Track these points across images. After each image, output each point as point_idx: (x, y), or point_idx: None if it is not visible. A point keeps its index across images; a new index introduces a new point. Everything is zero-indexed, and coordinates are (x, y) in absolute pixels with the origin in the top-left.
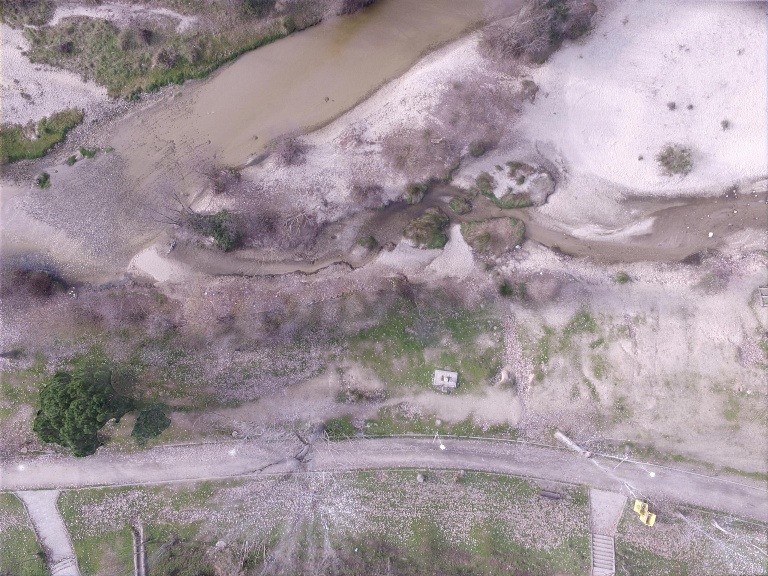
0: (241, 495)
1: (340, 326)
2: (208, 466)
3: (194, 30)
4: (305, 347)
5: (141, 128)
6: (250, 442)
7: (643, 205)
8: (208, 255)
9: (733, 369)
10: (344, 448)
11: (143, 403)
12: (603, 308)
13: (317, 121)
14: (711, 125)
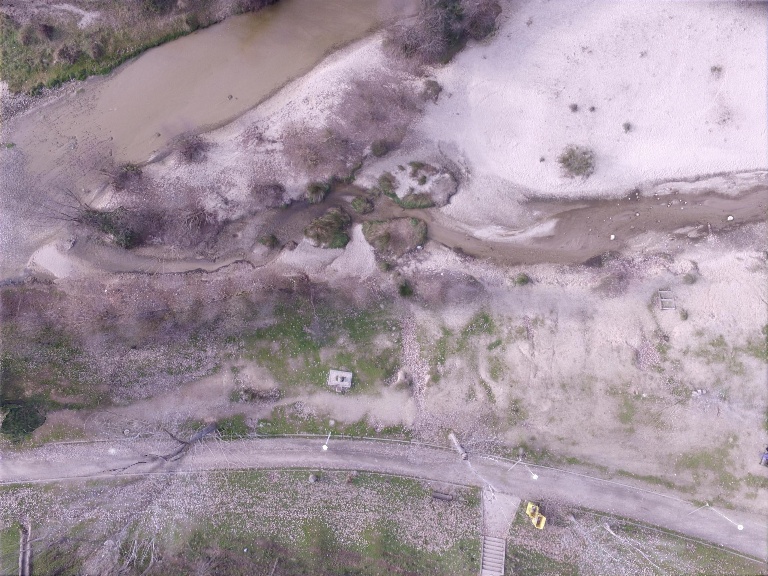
0: (132, 494)
1: (238, 325)
2: (99, 464)
3: (96, 26)
4: (201, 345)
5: (43, 124)
6: (142, 440)
7: (545, 207)
8: (109, 252)
9: (629, 372)
10: (237, 447)
11: (34, 400)
12: (502, 309)
13: (220, 119)
14: (613, 127)
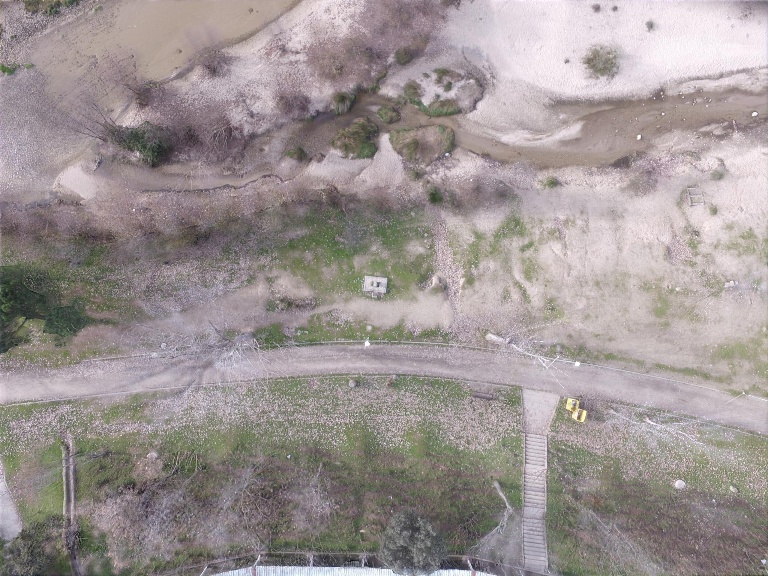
0: (172, 407)
1: (269, 237)
2: (137, 379)
3: None
4: (234, 258)
5: (62, 43)
6: (179, 353)
7: (571, 109)
8: (135, 171)
9: (662, 267)
10: (275, 357)
11: None
12: (533, 212)
13: (242, 33)
14: (636, 26)
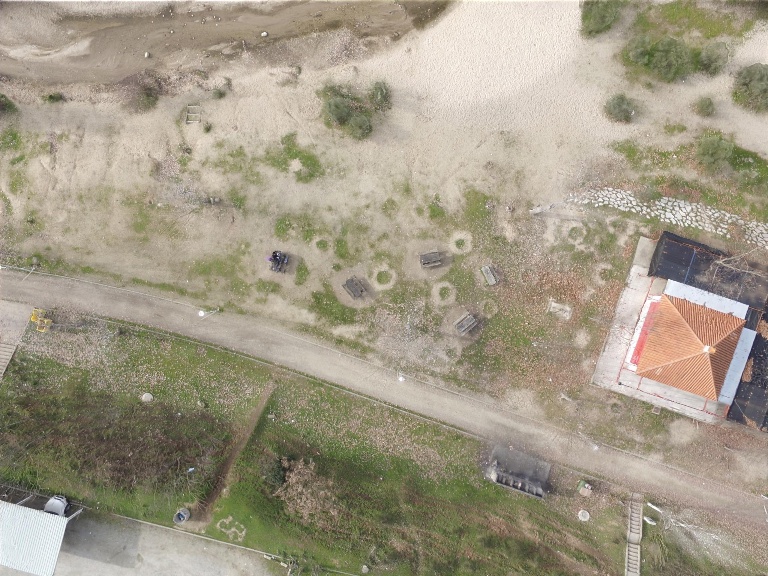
0: None
1: None
2: None
3: None
4: None
5: None
6: None
7: (79, 25)
8: None
9: (146, 183)
10: None
11: None
12: (31, 126)
13: None
14: None
